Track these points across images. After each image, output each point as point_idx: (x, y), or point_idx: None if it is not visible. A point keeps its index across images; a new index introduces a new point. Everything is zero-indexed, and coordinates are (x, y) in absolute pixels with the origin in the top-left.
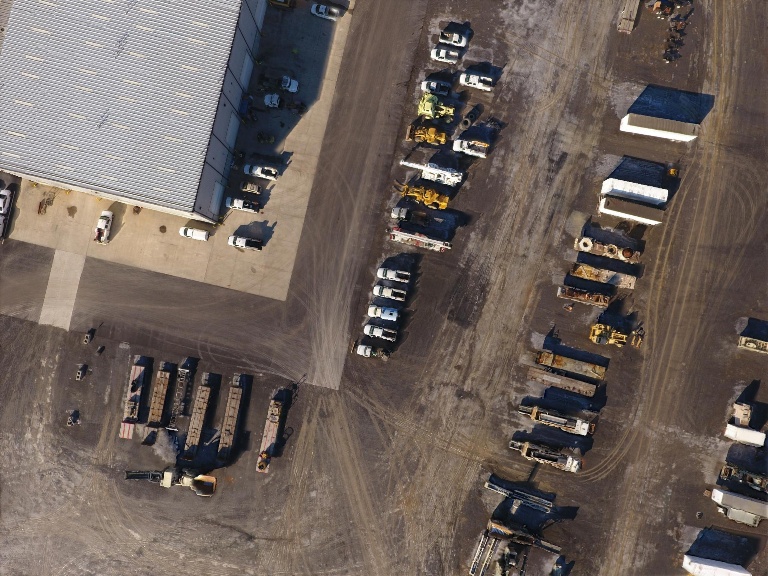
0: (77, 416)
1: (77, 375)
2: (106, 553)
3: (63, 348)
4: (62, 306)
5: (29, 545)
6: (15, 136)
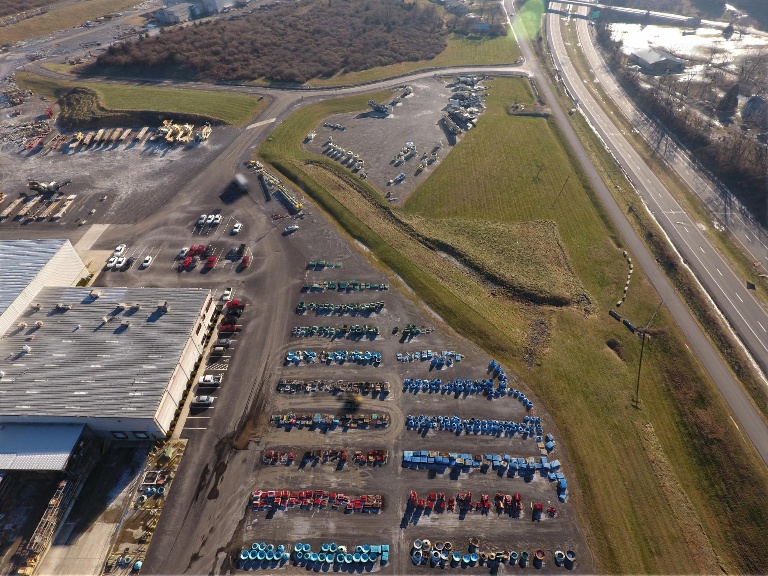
0: (101, 200)
1: (94, 210)
2: (103, 168)
3: (100, 218)
4: (94, 231)
5: (140, 166)
6: (39, 251)
